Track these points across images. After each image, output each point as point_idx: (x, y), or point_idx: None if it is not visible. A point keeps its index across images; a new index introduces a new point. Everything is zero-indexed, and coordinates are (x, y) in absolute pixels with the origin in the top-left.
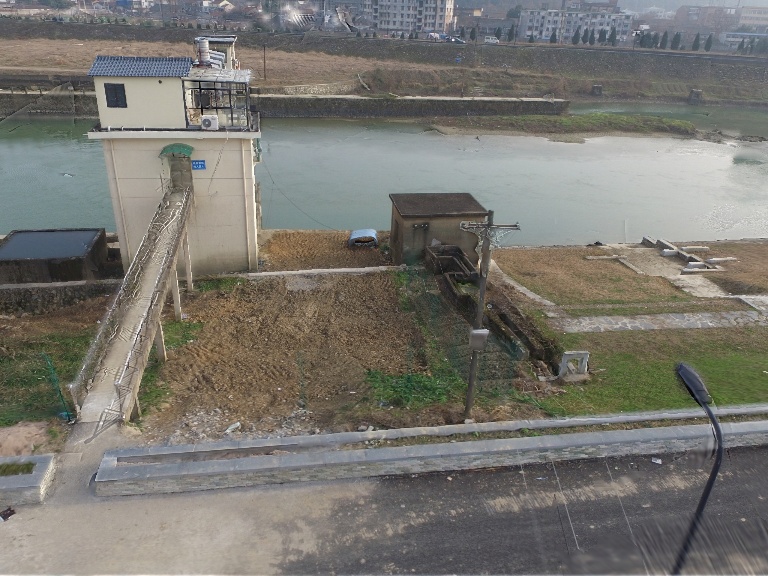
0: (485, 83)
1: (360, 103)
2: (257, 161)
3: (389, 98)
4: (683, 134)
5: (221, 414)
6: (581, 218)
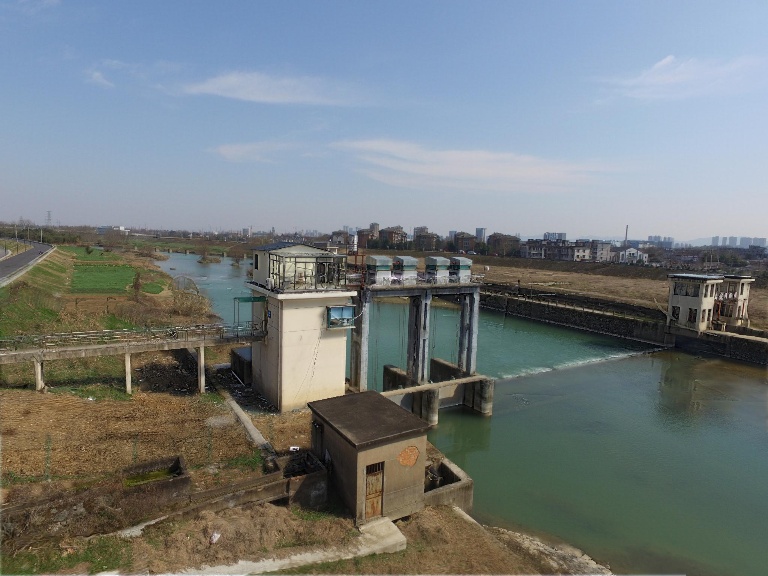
0: None
1: None
2: (328, 327)
3: None
4: None
5: None
6: None
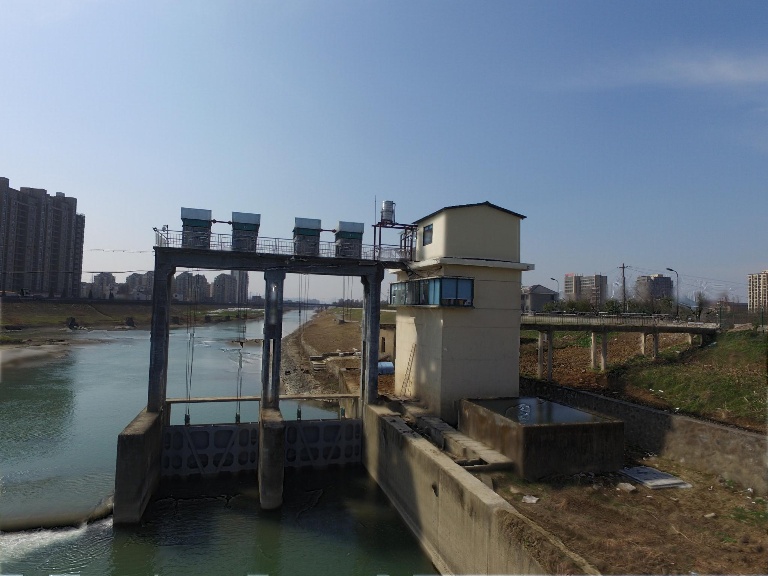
0: None
1: None
2: None
3: None
4: (17, 344)
5: (666, 337)
6: (219, 375)
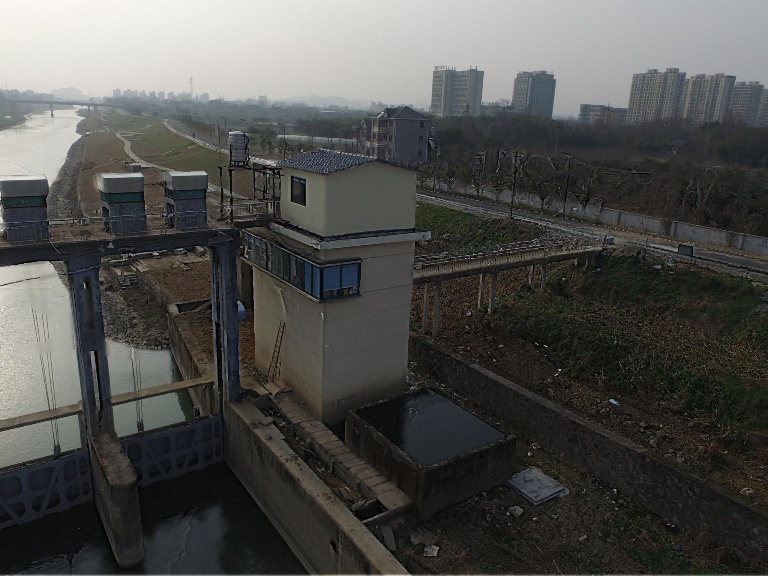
0: None
1: None
2: None
3: None
4: None
5: None
6: None
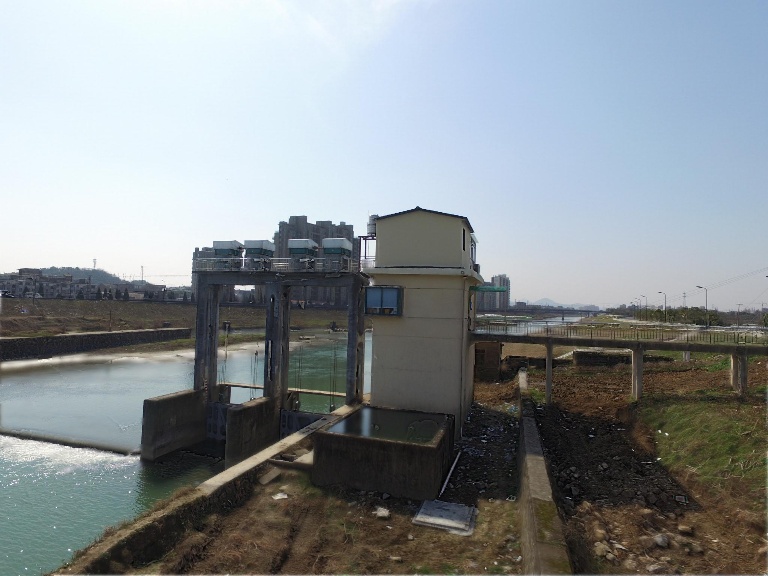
0: (72, 327)
1: (15, 343)
2: None
3: (48, 336)
4: None
5: None
6: None
